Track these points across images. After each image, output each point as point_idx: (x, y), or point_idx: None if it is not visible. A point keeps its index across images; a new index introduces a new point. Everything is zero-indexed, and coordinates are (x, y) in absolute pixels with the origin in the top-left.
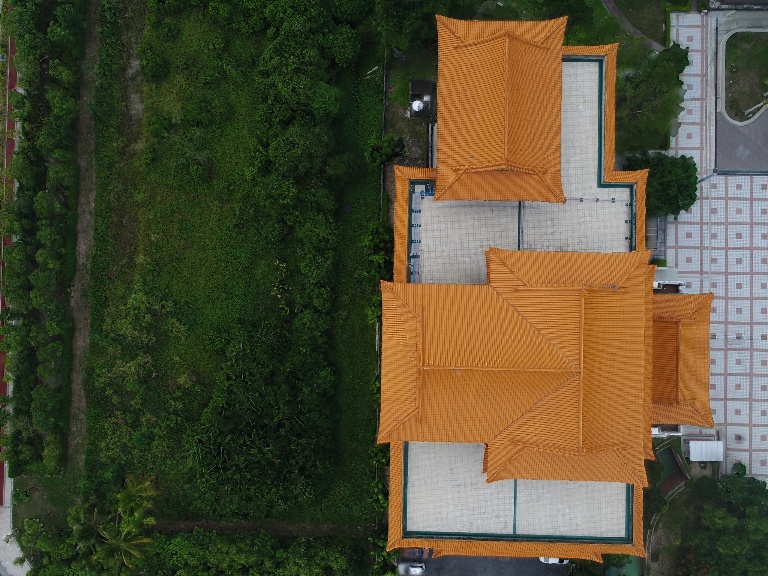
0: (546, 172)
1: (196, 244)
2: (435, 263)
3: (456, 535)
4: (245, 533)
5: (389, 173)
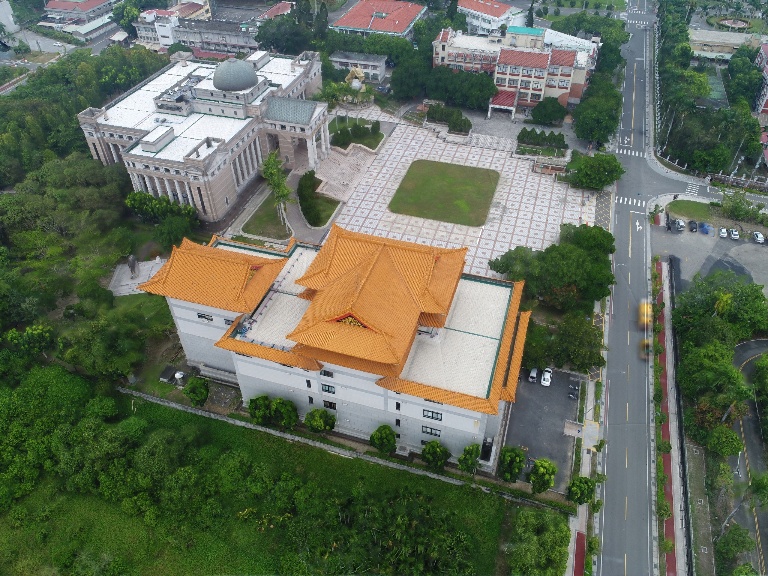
0: None
1: None
2: None
3: None
4: None
5: (216, 411)
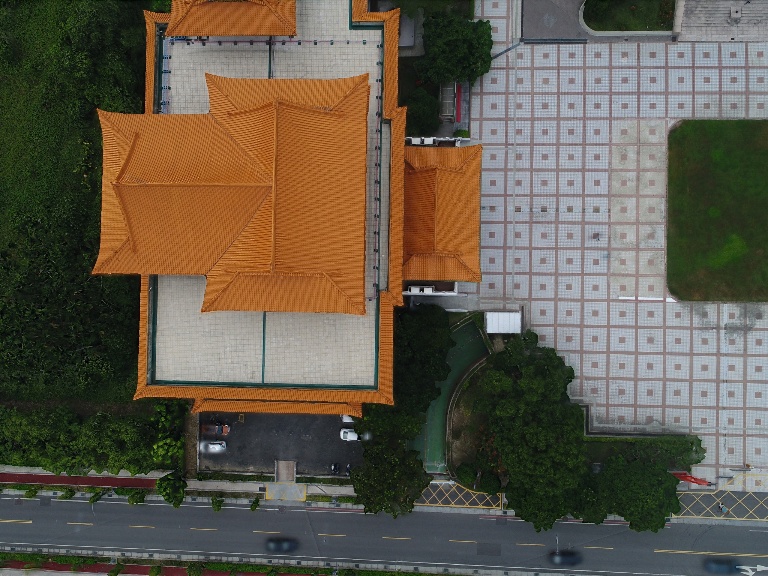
0: (278, 4)
1: (5, 125)
2: (185, 109)
3: (204, 384)
4: (42, 407)
5: None
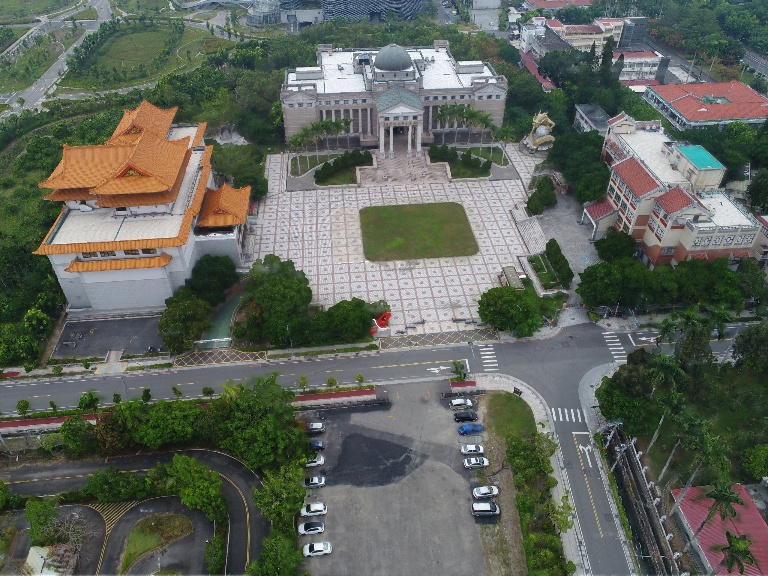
0: None
1: None
2: None
3: None
4: None
5: None
